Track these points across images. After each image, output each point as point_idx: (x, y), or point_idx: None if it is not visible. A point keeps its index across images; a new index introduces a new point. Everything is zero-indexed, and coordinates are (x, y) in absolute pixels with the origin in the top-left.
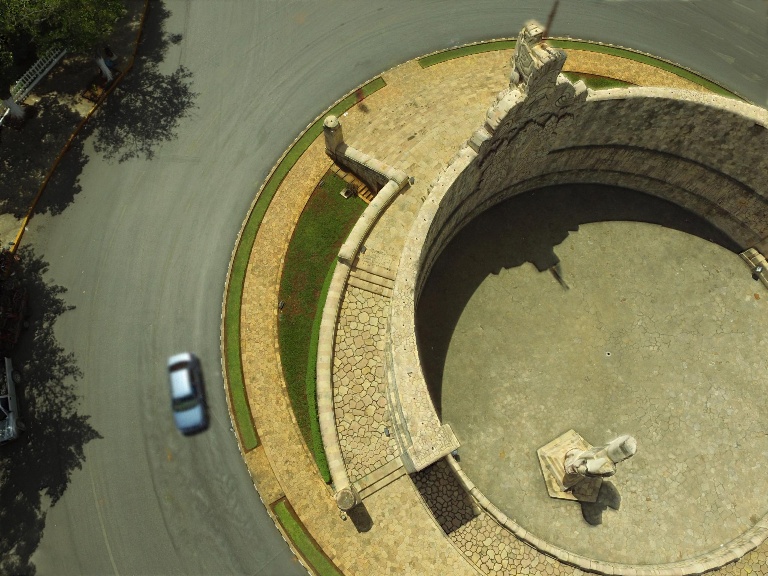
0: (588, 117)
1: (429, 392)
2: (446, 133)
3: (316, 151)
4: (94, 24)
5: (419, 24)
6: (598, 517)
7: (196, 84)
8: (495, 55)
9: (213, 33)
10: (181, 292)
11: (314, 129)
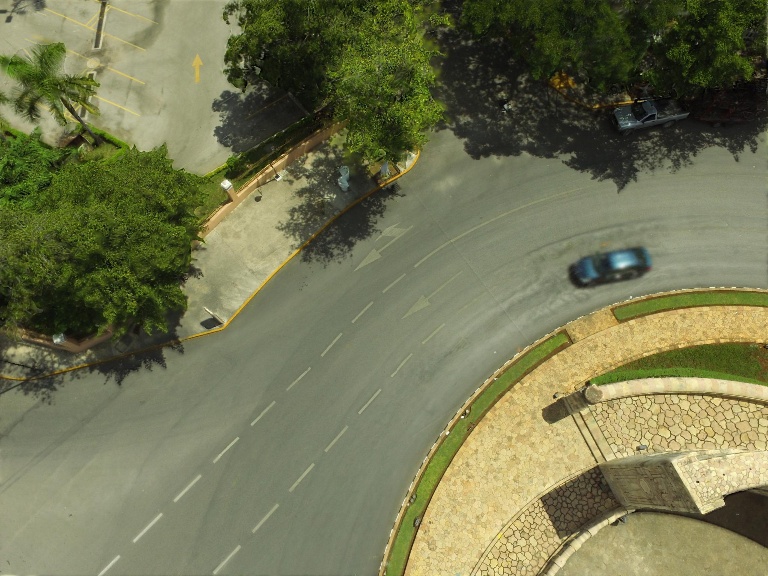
0: None
1: None
2: None
3: None
4: None
5: None
6: None
7: None
8: None
9: None
10: (767, 250)
11: None
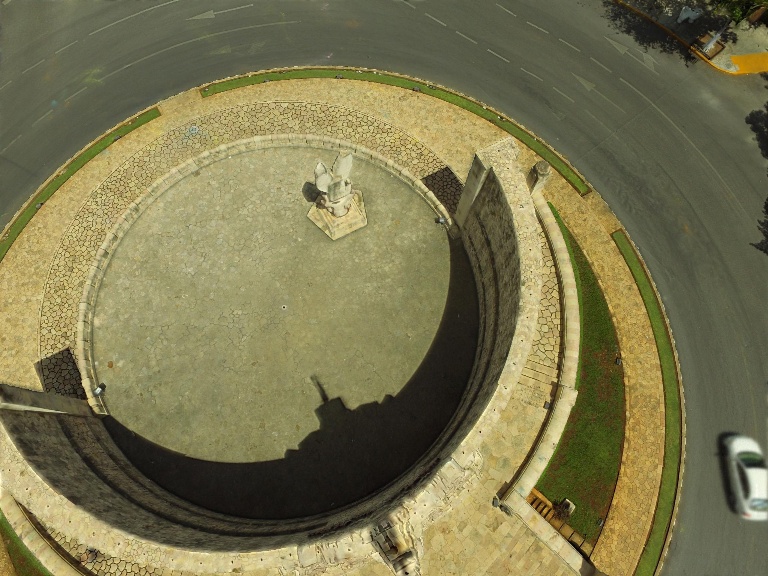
0: None
1: (462, 275)
2: None
3: None
4: None
5: None
6: None
7: None
8: None
9: None
10: (728, 382)
11: None
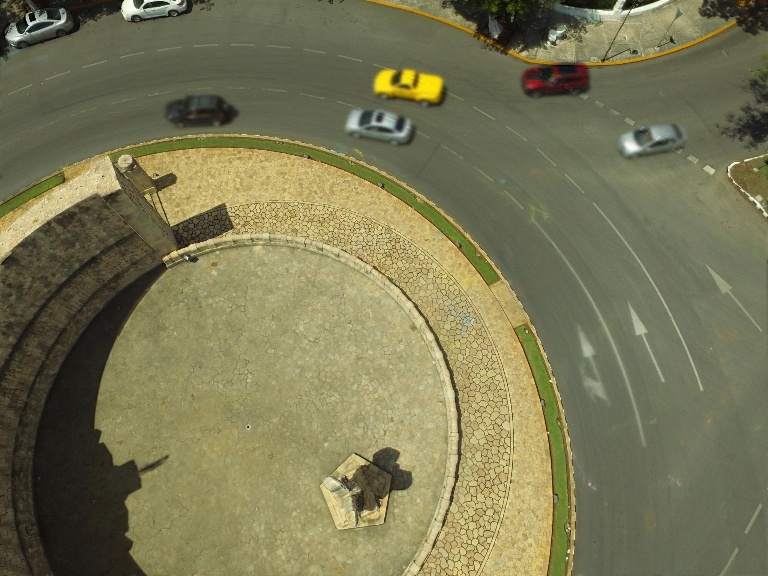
0: None
1: None
2: None
3: None
4: None
5: None
6: (405, 475)
7: None
8: None
9: None
10: None
11: None
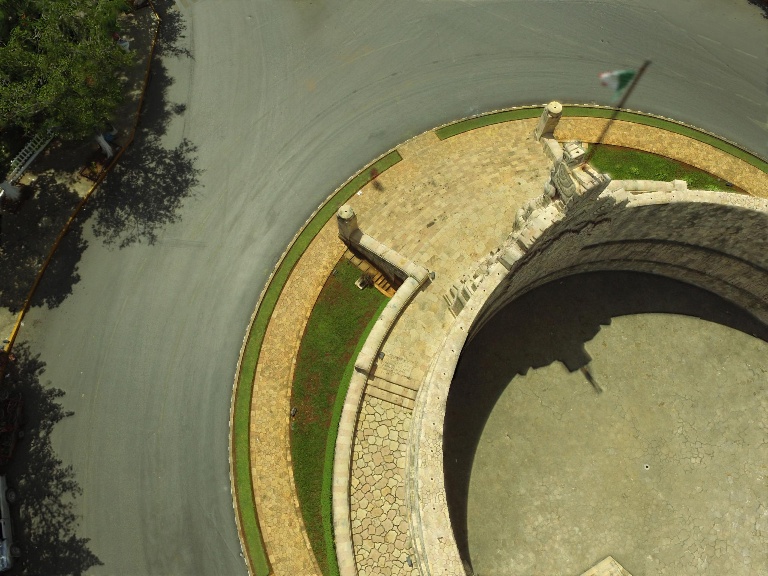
0: (626, 219)
1: (454, 512)
2: (468, 220)
3: (328, 235)
4: (92, 114)
5: (436, 90)
6: None
7: (201, 159)
8: (517, 125)
9: (218, 102)
10: (186, 395)
11: (326, 210)
